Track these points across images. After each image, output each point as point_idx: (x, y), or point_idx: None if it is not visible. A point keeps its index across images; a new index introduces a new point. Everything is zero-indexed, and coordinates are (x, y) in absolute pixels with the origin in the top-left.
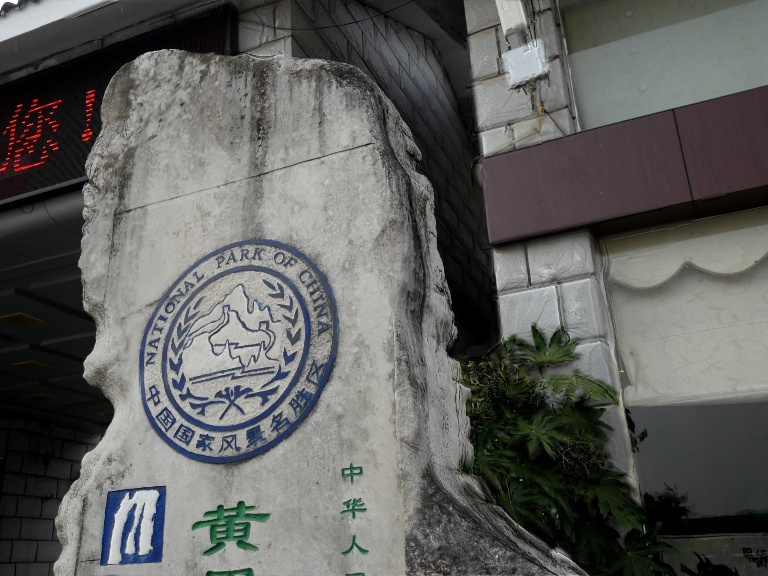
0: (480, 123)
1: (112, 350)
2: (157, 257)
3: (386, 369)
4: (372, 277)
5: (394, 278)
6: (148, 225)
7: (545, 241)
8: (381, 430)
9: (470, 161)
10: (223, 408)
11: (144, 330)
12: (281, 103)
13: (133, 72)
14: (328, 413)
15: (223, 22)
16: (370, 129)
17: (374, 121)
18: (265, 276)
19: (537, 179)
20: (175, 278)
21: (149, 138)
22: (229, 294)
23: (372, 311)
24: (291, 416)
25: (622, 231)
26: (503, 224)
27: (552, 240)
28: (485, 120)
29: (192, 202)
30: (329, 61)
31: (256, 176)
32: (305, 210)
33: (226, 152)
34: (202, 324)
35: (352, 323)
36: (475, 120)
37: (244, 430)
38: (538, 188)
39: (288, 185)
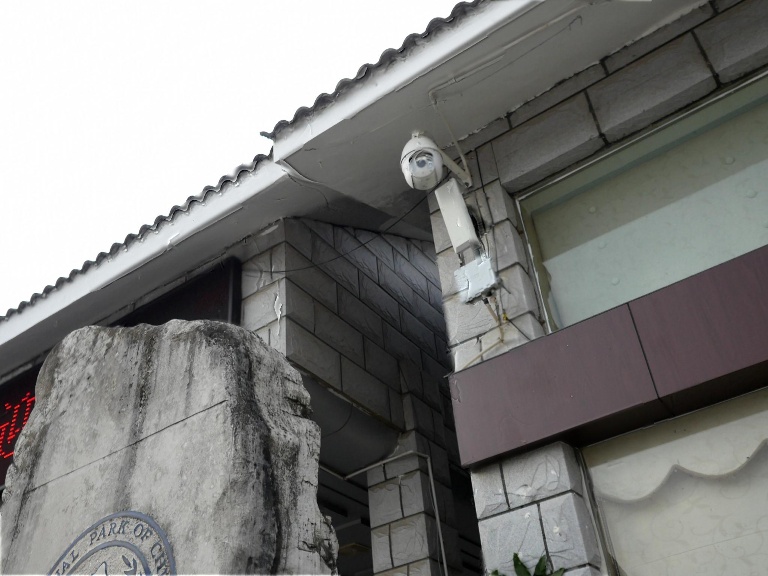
0: (452, 337)
1: None
2: (46, 537)
3: None
4: (209, 546)
5: (228, 546)
6: (46, 503)
7: (519, 455)
8: None
9: None
10: None
11: None
12: (161, 368)
13: (60, 351)
14: None
15: (226, 274)
16: (226, 386)
17: (231, 377)
18: (124, 551)
19: (510, 388)
20: (57, 558)
21: (60, 414)
22: (94, 573)
23: None
24: None
25: (597, 435)
26: (475, 441)
27: (525, 454)
28: (457, 334)
29: (82, 476)
30: (205, 321)
31: (133, 444)
32: (165, 476)
33: (114, 422)
34: None
35: None
36: (446, 335)
37: None
38: (512, 398)
39: (155, 451)
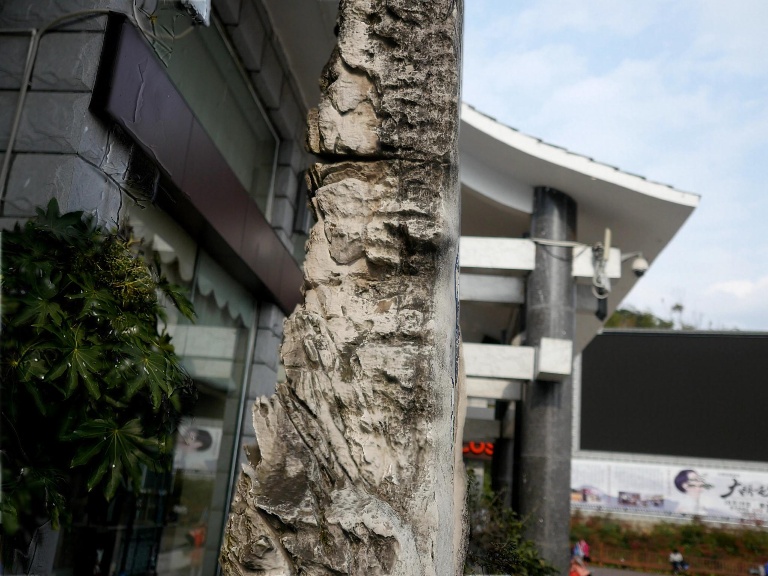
0: None
1: None
2: None
3: None
4: None
5: None
6: None
7: None
8: None
9: (113, 3)
10: None
11: None
12: None
13: None
14: None
15: None
16: None
17: None
18: None
19: None
20: None
21: None
22: None
23: None
24: None
25: None
26: None
27: None
28: None
29: None
30: None
31: None
32: None
33: None
34: None
35: None
36: None
37: None
38: None
39: None
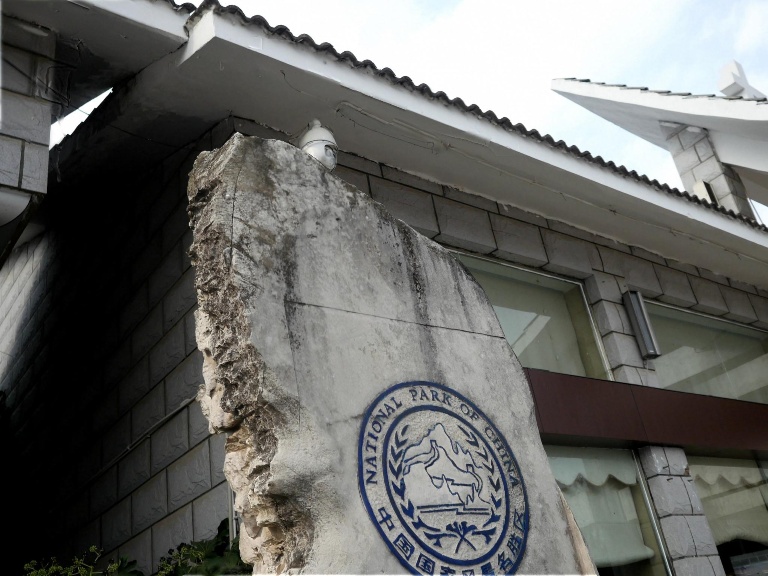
0: None
1: (322, 457)
2: (349, 368)
3: (563, 526)
4: (536, 448)
5: None
6: (330, 329)
7: None
8: (573, 575)
9: None
10: (456, 542)
11: (358, 444)
12: (429, 269)
13: (269, 152)
14: (537, 557)
15: None
16: (499, 326)
17: None
18: (458, 422)
19: None
20: (373, 397)
21: (308, 235)
22: (433, 430)
23: (544, 476)
24: (511, 557)
25: None
26: None
27: None
28: None
29: (370, 324)
30: None
31: (424, 325)
32: (473, 373)
33: (392, 289)
34: (416, 453)
35: (533, 483)
36: None
37: (479, 566)
38: None
39: (455, 346)
